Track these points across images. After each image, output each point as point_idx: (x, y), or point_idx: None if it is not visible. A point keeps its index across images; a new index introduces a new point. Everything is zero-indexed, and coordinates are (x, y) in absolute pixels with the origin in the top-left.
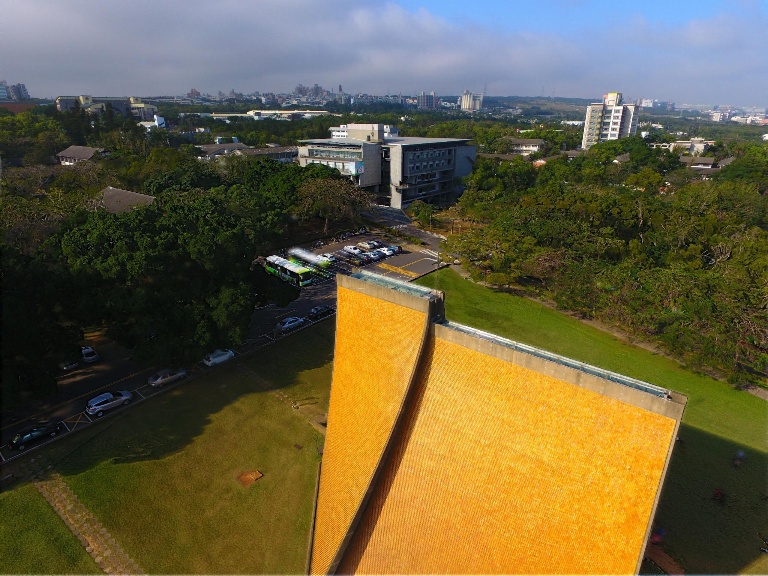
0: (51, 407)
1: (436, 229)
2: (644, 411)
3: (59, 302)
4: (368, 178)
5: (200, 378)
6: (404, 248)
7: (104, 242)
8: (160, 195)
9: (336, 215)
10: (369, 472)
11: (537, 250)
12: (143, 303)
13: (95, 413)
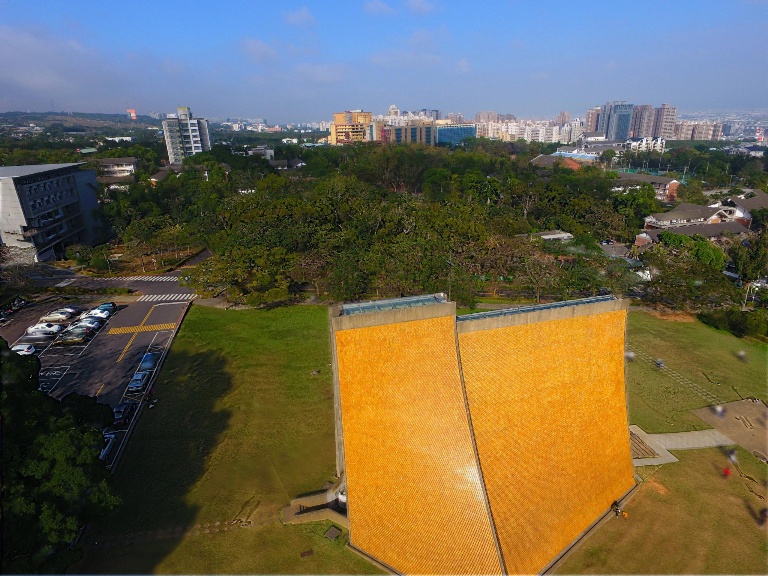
0: None
1: (118, 272)
2: (611, 313)
3: None
4: None
5: None
6: None
7: None
8: None
9: None
10: (476, 484)
11: (290, 258)
12: None
13: None
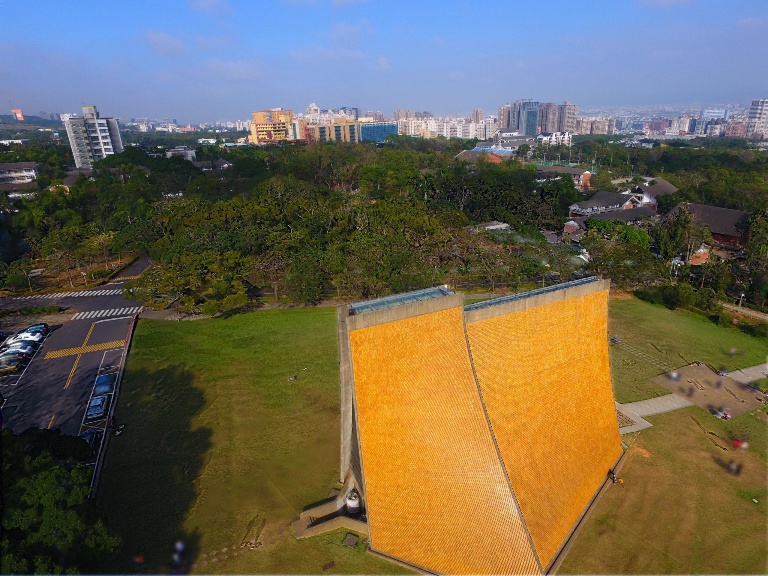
0: None
1: (41, 290)
2: (596, 293)
3: None
4: None
5: None
6: None
7: None
8: None
9: None
10: (498, 471)
11: (245, 261)
12: None
13: None
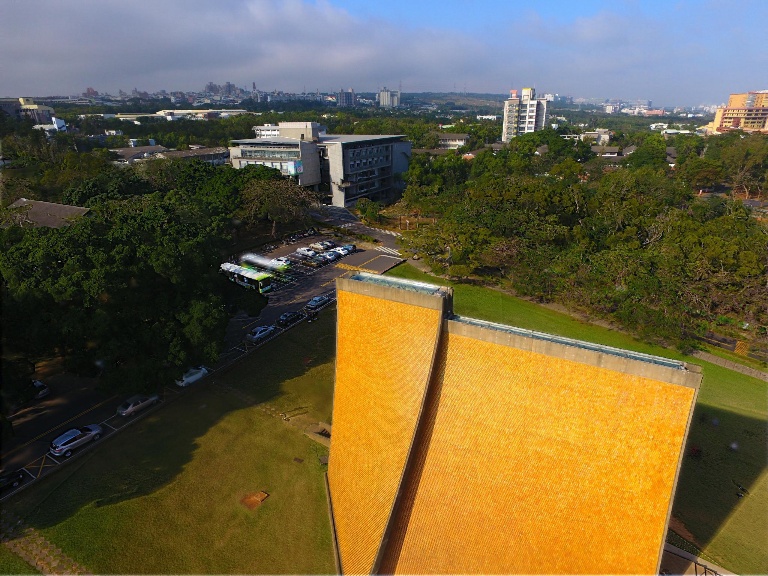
0: (4, 454)
1: (384, 226)
2: (664, 384)
3: (3, 333)
4: (308, 177)
5: (175, 401)
6: (357, 247)
7: (51, 261)
8: (105, 205)
9: (286, 217)
10: (396, 476)
11: (492, 240)
12: (107, 326)
13: (62, 454)
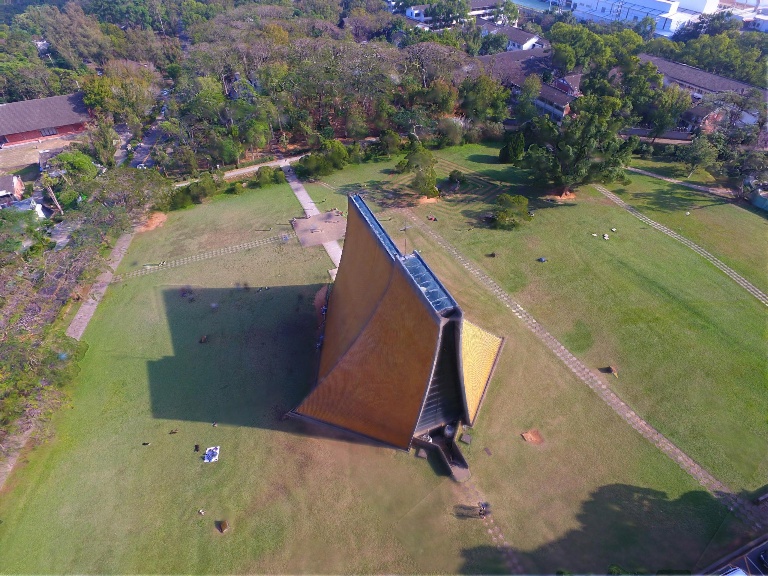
0: None
1: None
2: None
3: None
4: None
5: None
6: None
7: None
8: None
9: None
10: None
11: None
12: None
13: None
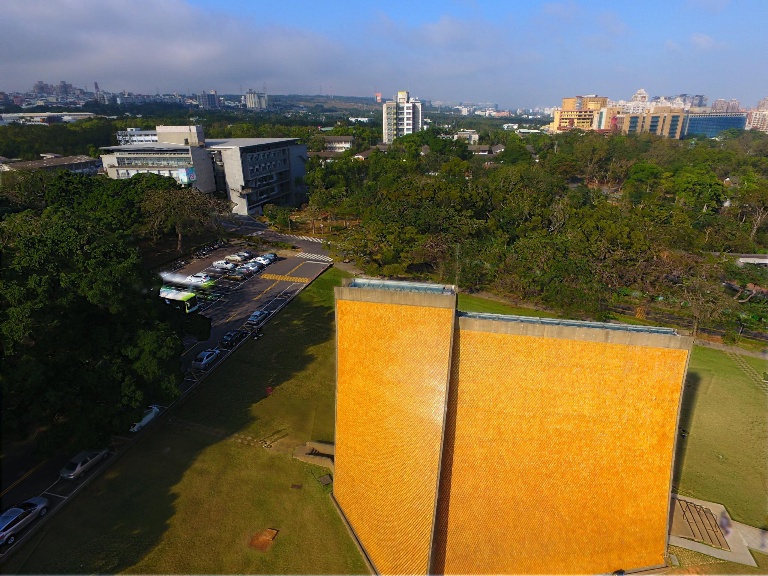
0: None
1: (296, 231)
2: (663, 349)
3: None
4: (202, 185)
5: (130, 450)
6: None
7: None
8: None
9: (198, 229)
10: (432, 480)
11: (419, 238)
12: (41, 374)
13: (4, 542)
